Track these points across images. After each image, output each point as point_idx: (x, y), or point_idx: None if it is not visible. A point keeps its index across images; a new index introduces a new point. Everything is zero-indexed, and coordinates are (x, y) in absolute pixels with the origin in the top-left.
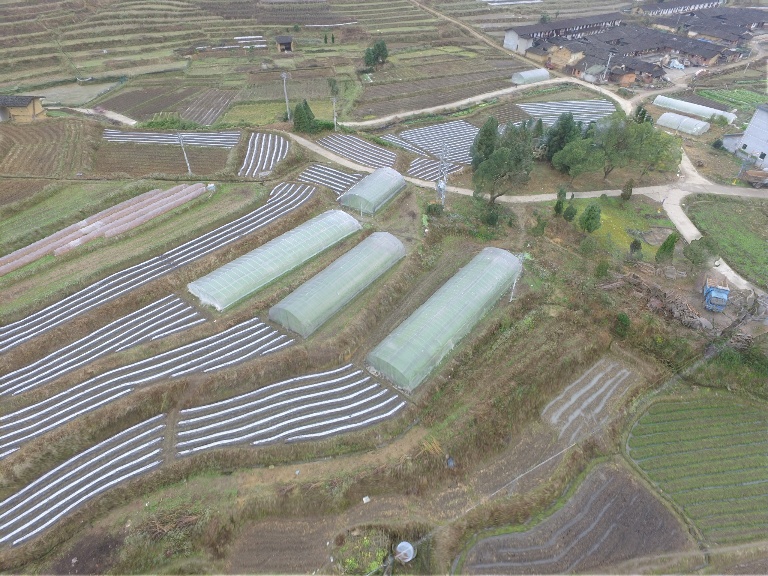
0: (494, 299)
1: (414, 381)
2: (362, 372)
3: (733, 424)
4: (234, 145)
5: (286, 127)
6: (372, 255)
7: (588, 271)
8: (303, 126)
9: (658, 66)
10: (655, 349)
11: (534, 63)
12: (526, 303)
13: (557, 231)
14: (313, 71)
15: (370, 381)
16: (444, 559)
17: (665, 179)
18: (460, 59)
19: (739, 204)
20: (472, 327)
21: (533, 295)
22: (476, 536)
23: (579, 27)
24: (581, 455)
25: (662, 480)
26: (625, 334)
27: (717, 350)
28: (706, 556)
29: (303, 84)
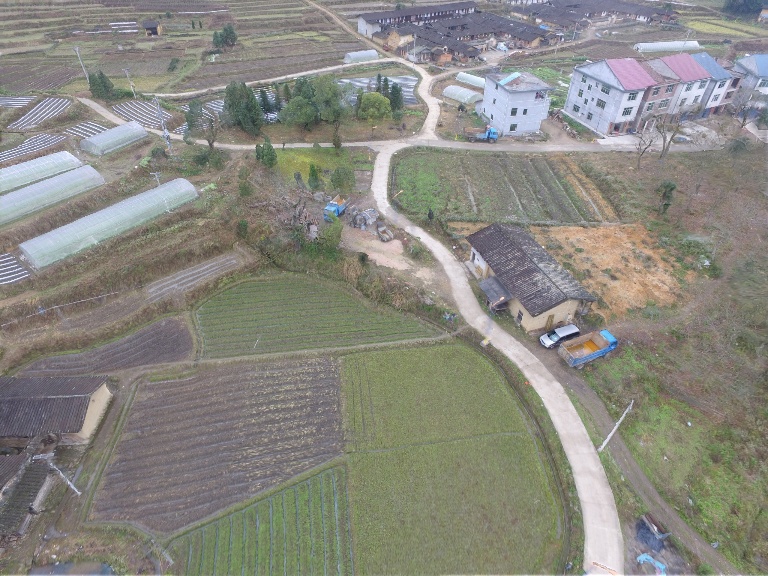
0: (155, 213)
1: (42, 261)
2: (13, 258)
3: (292, 294)
4: (22, 106)
5: (88, 94)
6: (63, 180)
7: (252, 195)
8: (97, 93)
9: (473, 47)
10: (261, 245)
11: (376, 46)
12: (185, 217)
13: (253, 169)
14: (165, 52)
15: (15, 264)
16: (4, 366)
17: (399, 135)
18: (309, 42)
19: (448, 154)
20: (124, 231)
21: (192, 211)
22: (41, 356)
23: (431, 14)
24: (154, 310)
25: (207, 325)
26: (246, 236)
27: (285, 240)
28: (195, 364)
29: (149, 63)
